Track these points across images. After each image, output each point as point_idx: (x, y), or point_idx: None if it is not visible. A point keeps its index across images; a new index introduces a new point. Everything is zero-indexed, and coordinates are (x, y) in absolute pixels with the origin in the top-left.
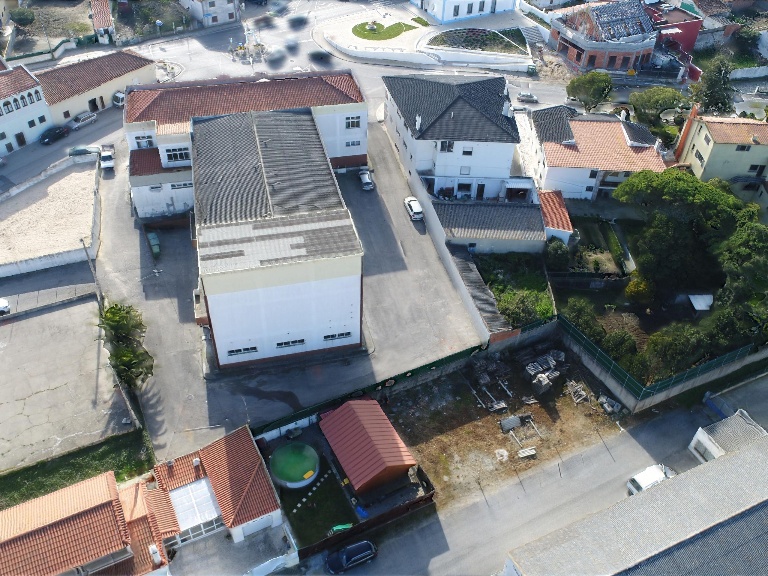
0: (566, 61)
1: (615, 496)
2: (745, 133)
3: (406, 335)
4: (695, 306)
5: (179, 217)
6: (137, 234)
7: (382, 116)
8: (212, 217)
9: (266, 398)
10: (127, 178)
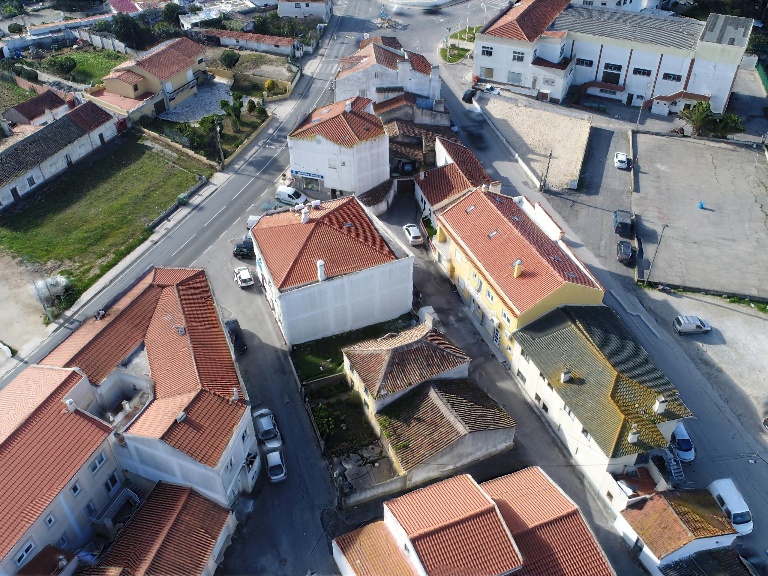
0: None
1: None
2: None
3: None
4: (759, 26)
5: (570, 95)
6: (576, 110)
7: None
8: (672, 46)
9: (750, 121)
10: (513, 94)
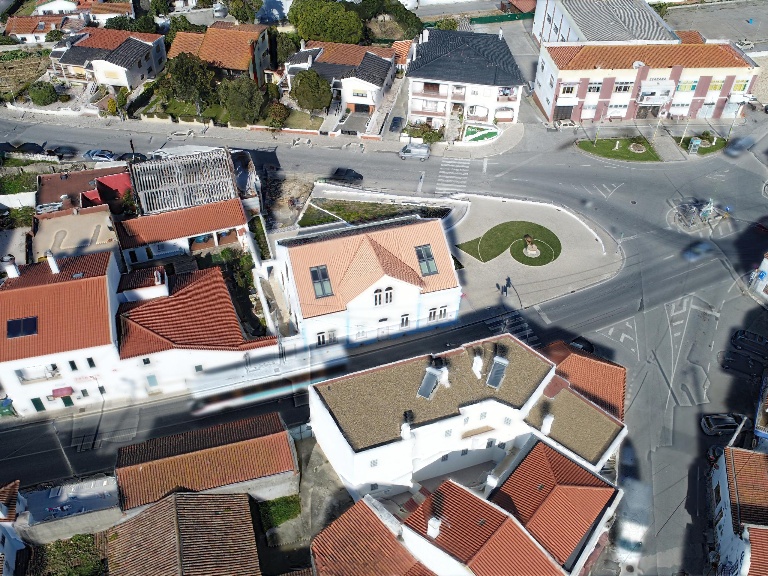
0: (263, 198)
1: (424, 8)
2: (238, 27)
3: (508, 36)
4: None
5: None
6: None
7: (519, 127)
8: None
9: None
10: None
